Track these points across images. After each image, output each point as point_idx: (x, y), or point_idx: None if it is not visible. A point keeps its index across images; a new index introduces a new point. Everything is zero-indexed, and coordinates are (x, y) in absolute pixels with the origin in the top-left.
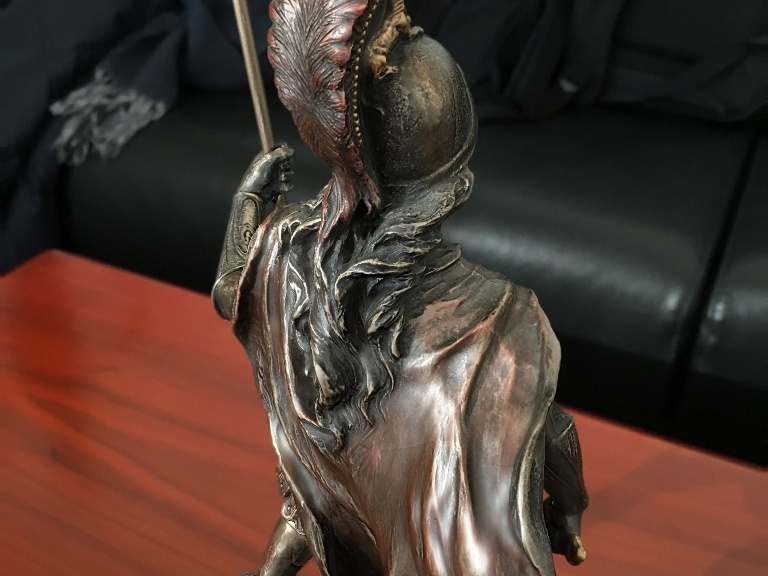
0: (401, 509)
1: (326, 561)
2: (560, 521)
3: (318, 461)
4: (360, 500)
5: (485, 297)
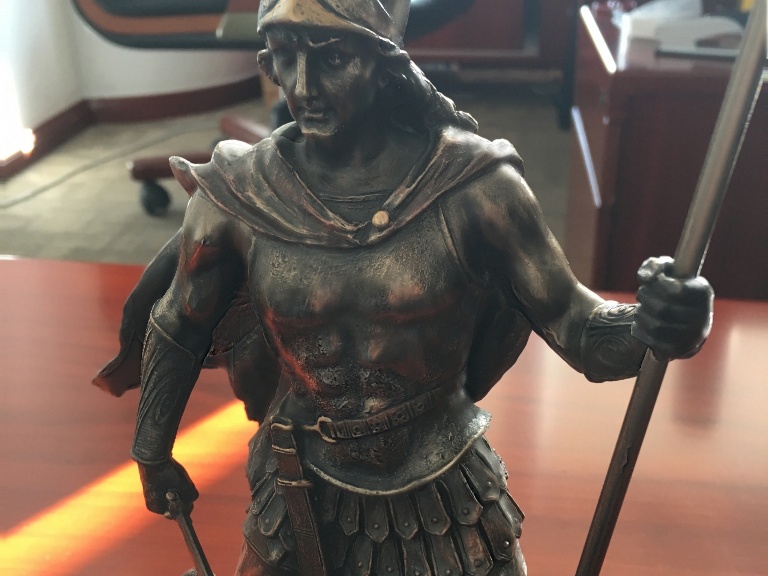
0: None
1: None
2: None
3: None
4: None
5: (242, 147)
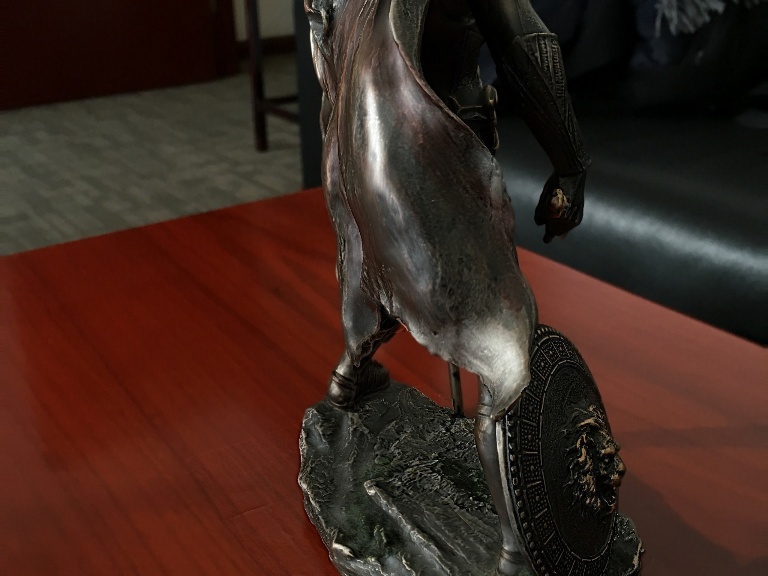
0: None
1: None
2: (554, 184)
3: (328, 76)
4: None
5: None
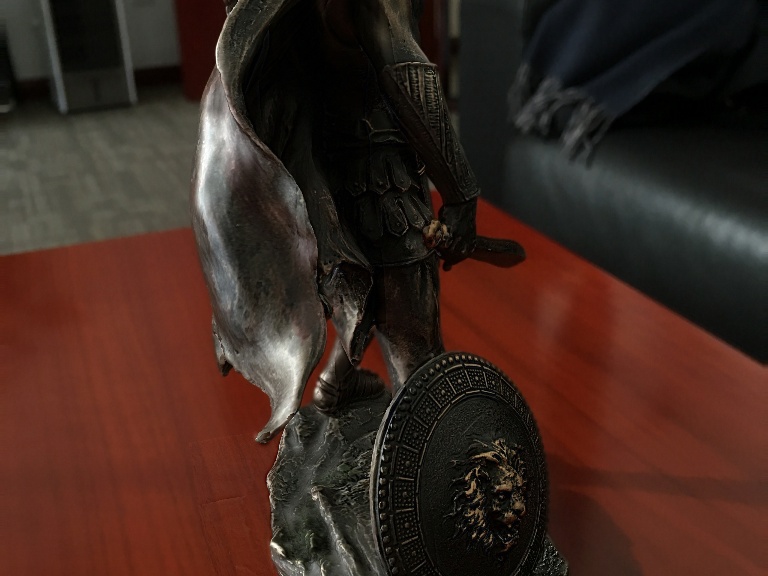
0: None
1: None
2: None
3: None
4: None
5: None
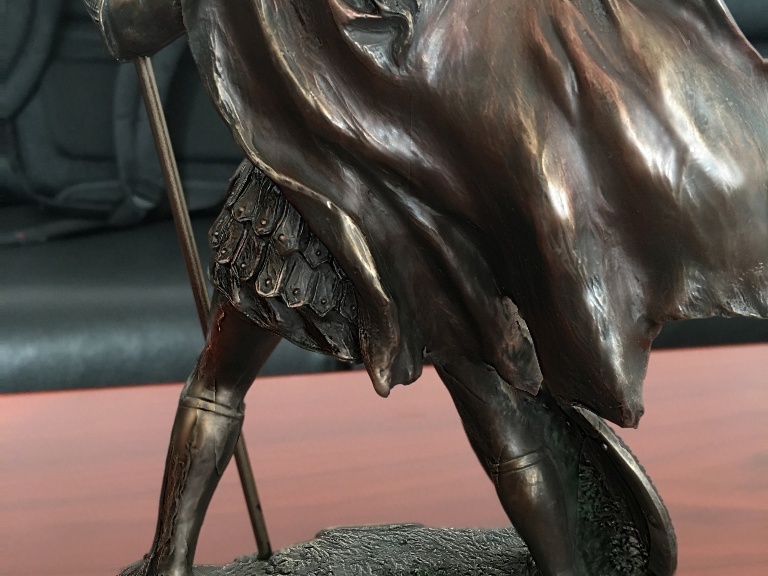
0: (520, 67)
1: (377, 272)
2: None
3: (356, 111)
4: (437, 120)
5: None
